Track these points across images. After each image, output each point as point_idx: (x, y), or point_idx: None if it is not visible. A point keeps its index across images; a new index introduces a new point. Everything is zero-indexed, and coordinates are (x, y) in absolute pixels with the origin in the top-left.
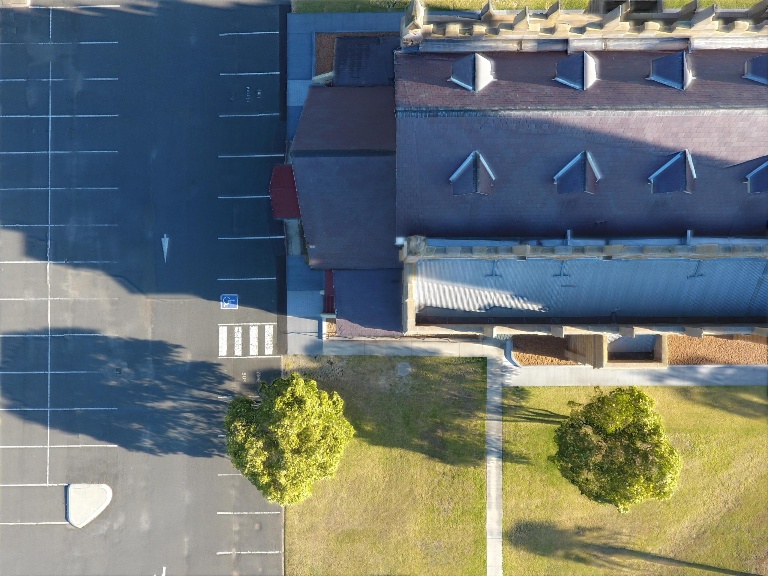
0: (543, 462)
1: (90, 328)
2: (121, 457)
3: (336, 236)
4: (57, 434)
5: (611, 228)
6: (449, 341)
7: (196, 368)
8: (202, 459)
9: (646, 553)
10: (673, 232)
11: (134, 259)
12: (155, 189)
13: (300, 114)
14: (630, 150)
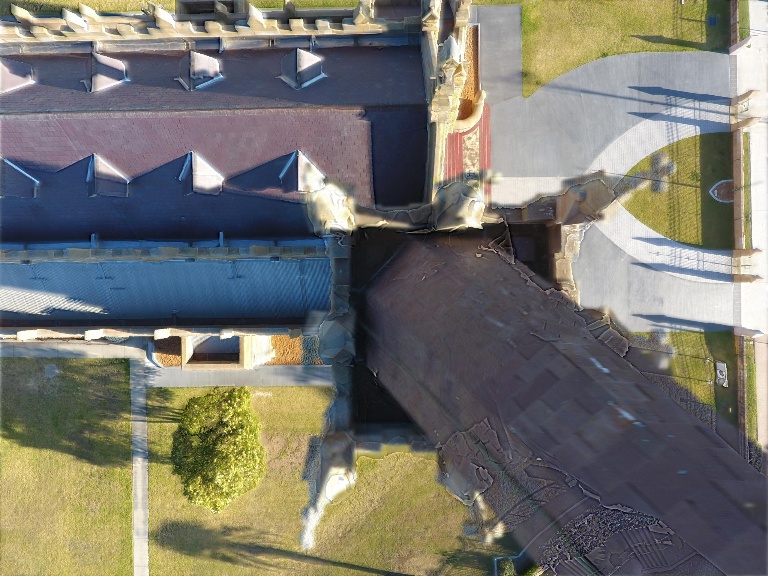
0: None
1: None
2: None
3: None
4: None
5: (15, 232)
6: (84, 343)
7: None
8: None
9: (293, 552)
10: (80, 236)
11: None
12: None
13: None
14: None
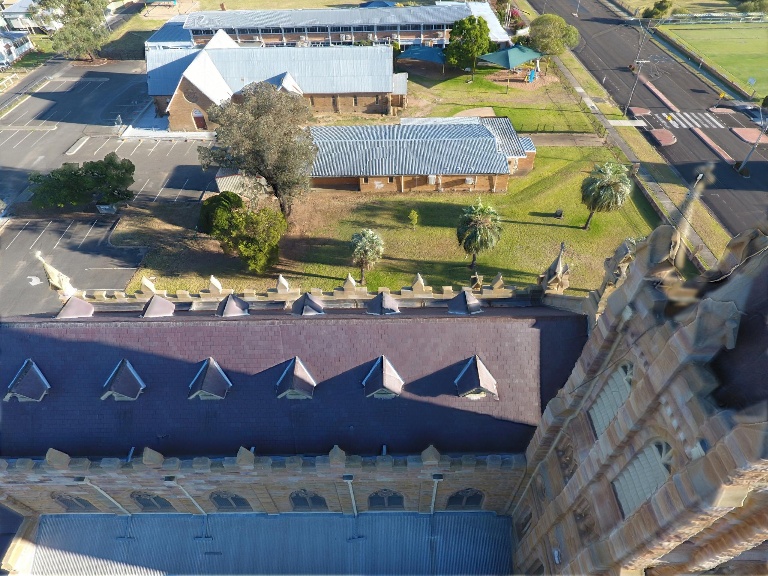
0: None
1: None
2: None
3: None
4: None
5: (175, 444)
6: None
7: None
8: None
9: None
10: None
11: None
12: None
13: None
14: (162, 358)
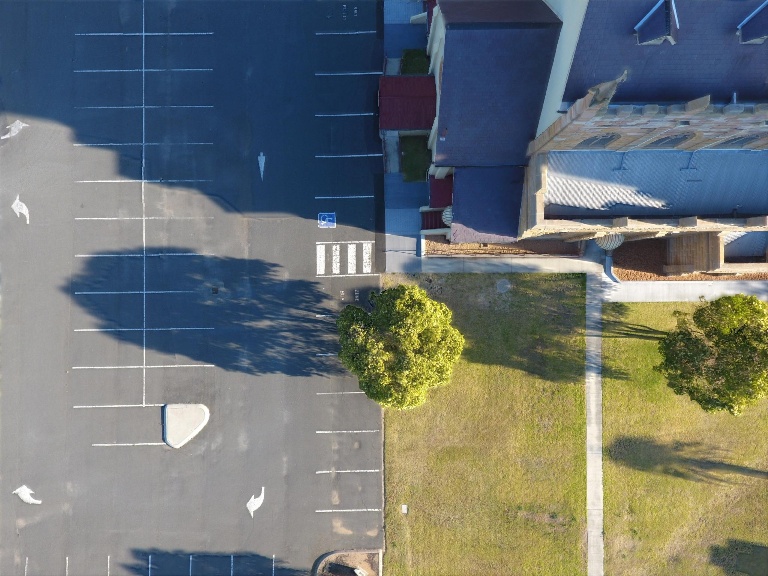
0: (642, 378)
1: (186, 247)
2: (218, 377)
3: (469, 126)
4: (153, 354)
5: None
6: (551, 255)
7: (294, 287)
8: (300, 378)
9: (743, 467)
10: None
11: (230, 178)
12: (251, 107)
13: (397, 32)
14: None
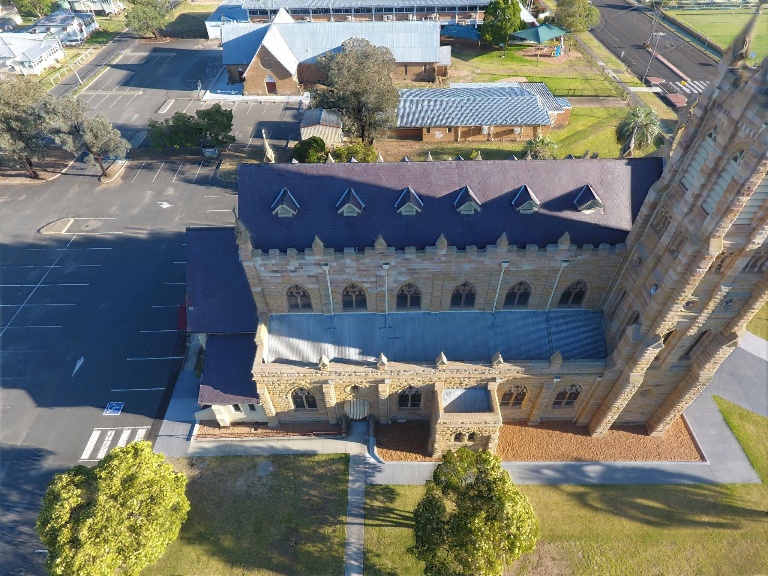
0: None
1: None
2: None
3: (210, 298)
4: None
5: None
6: None
7: (51, 472)
8: None
9: None
10: None
11: (45, 375)
12: (92, 327)
13: None
14: (376, 187)
